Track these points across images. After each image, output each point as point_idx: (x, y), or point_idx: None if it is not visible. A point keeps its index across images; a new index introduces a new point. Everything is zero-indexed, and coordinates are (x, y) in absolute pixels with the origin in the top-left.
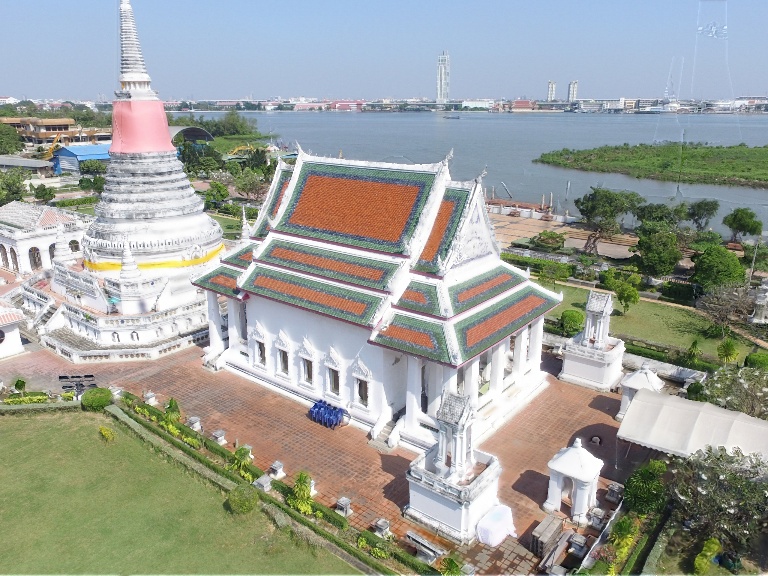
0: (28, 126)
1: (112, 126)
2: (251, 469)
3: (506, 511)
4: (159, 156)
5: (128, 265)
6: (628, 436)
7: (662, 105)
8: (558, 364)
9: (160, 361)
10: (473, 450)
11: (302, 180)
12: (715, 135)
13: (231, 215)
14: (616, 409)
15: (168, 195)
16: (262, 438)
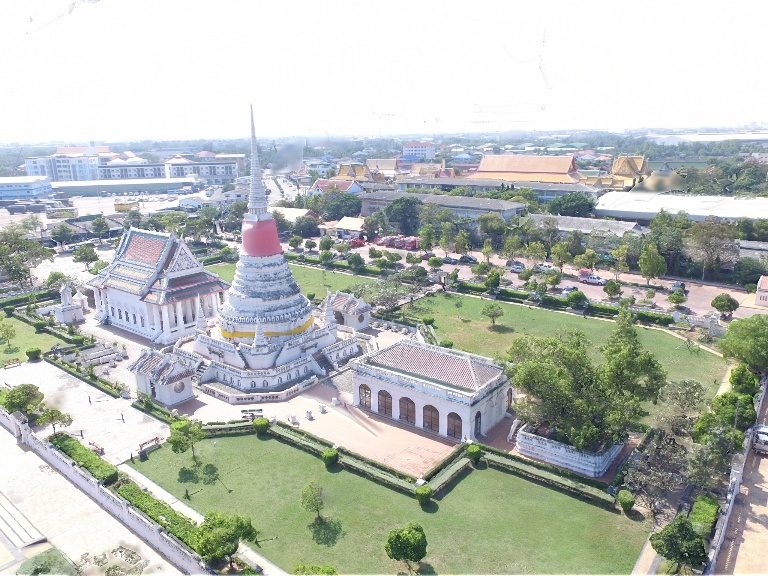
0: None
1: None
2: None
3: None
4: None
5: None
6: None
7: None
8: (74, 324)
9: None
10: None
11: None
12: None
13: None
14: (84, 312)
15: None
16: None
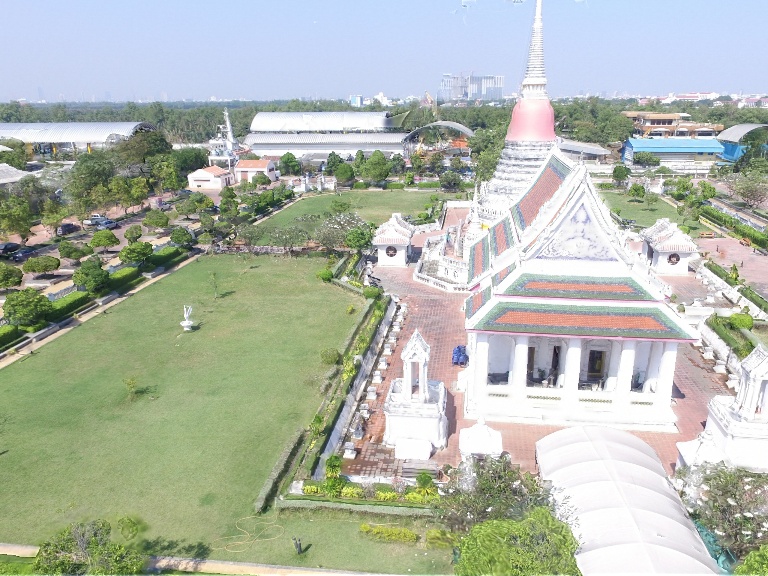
0: (641, 120)
1: None
2: (360, 350)
3: (425, 445)
4: (531, 145)
5: (473, 224)
6: (538, 447)
7: None
8: None
9: (450, 294)
10: (438, 394)
11: (544, 170)
12: None
13: (702, 217)
14: None
15: (528, 177)
16: None
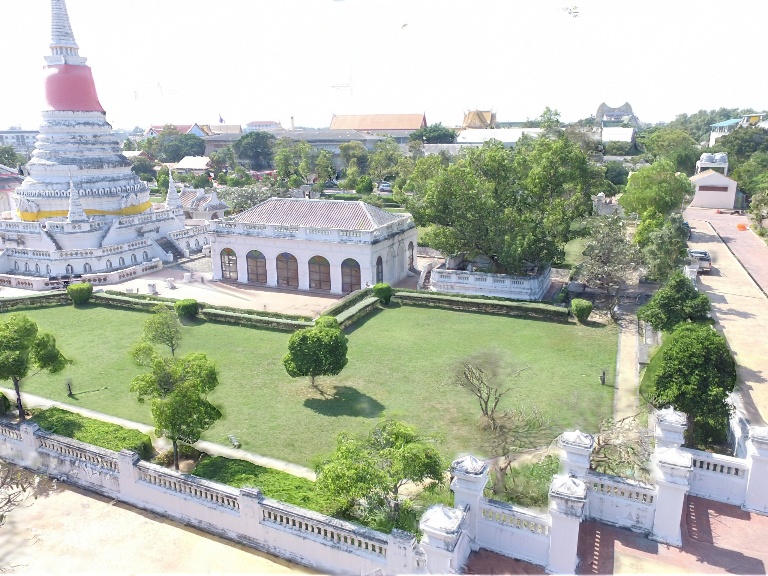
0: None
1: None
2: None
3: None
4: None
5: None
6: None
7: None
8: None
9: None
10: None
11: None
12: None
13: None
14: None
15: None
16: None
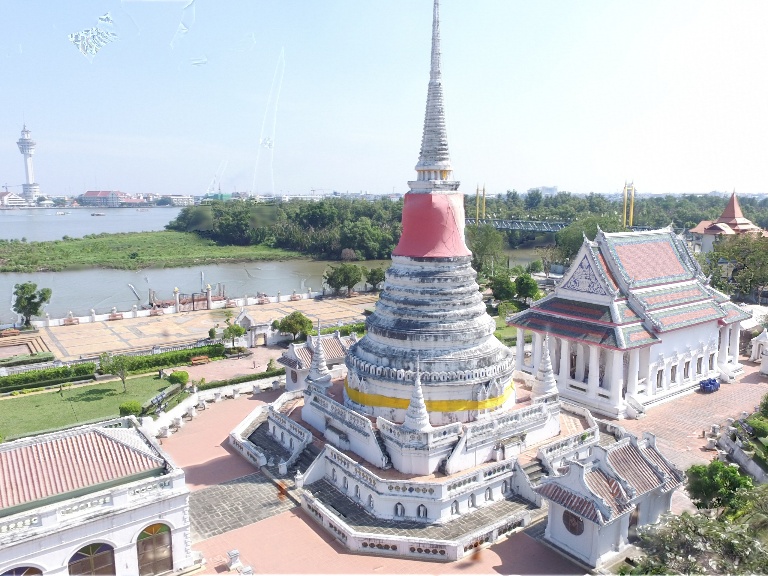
0: None
1: (443, 225)
2: None
3: None
4: None
5: None
6: None
7: (201, 200)
8: None
9: None
10: None
11: None
12: (263, 222)
13: None
14: None
15: None
16: (742, 405)
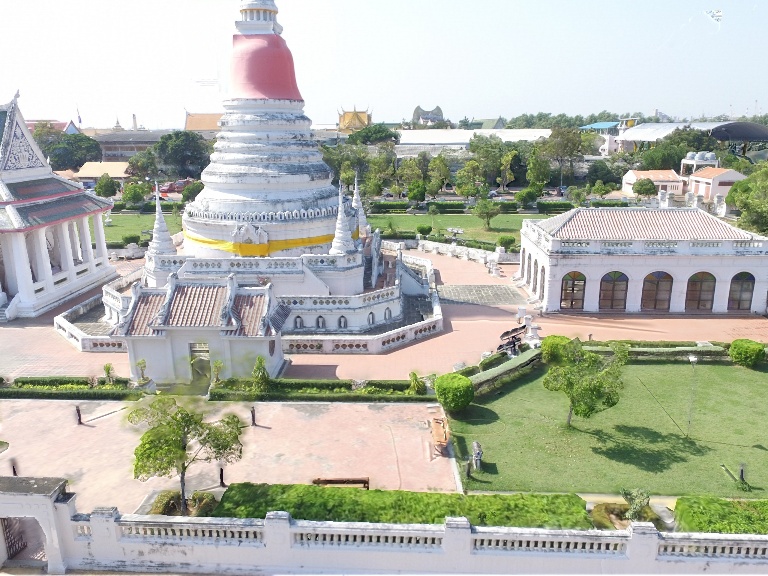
0: None
1: None
2: None
3: None
4: None
5: None
6: None
7: None
8: None
9: None
10: None
11: None
12: None
13: None
14: None
15: None
16: None
